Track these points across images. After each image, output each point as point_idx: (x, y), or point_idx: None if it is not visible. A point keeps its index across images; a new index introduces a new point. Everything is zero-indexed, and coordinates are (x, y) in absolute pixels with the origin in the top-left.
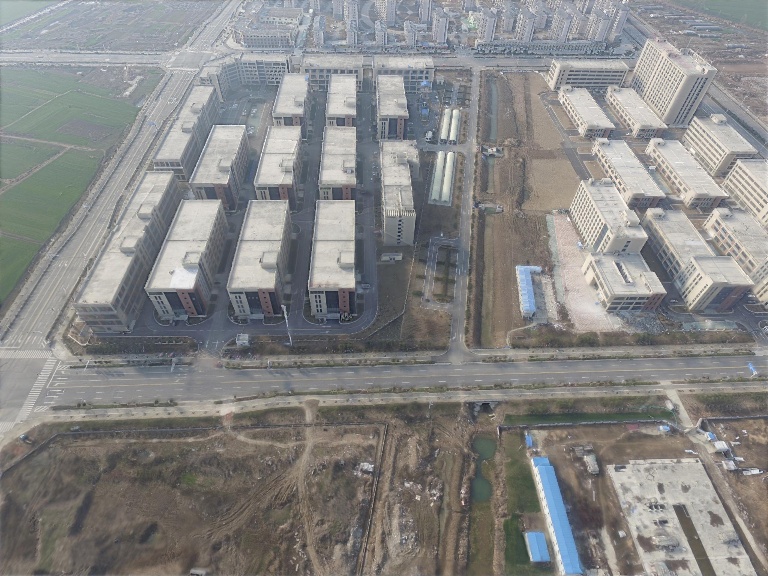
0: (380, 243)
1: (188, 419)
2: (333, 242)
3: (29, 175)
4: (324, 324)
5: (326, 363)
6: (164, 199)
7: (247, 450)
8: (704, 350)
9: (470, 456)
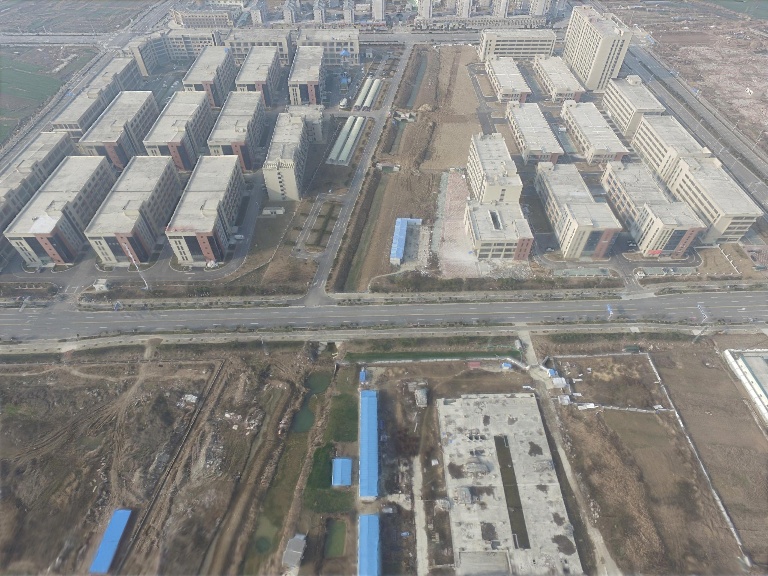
0: (266, 199)
1: (27, 355)
2: (204, 192)
3: None
4: (188, 271)
5: (178, 305)
6: (52, 157)
7: (77, 383)
8: (569, 294)
9: (301, 390)
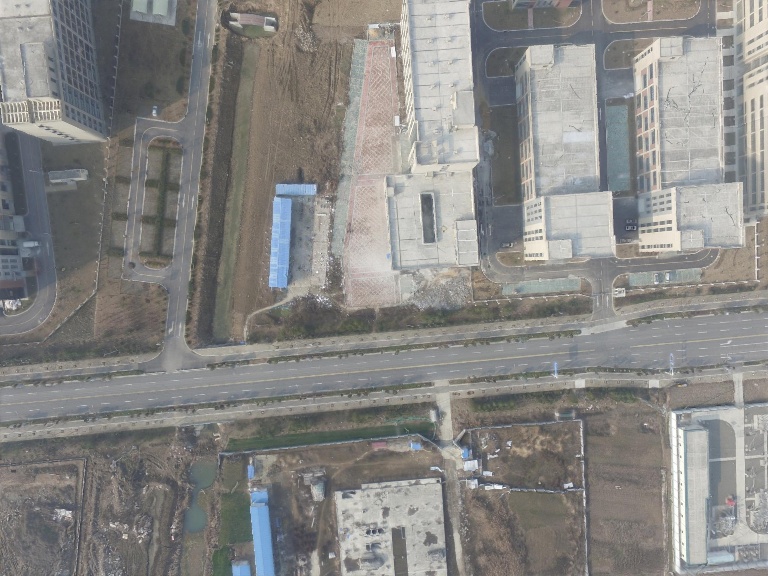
0: None
1: None
2: None
3: None
4: None
5: None
6: None
7: None
8: (514, 331)
9: (185, 487)
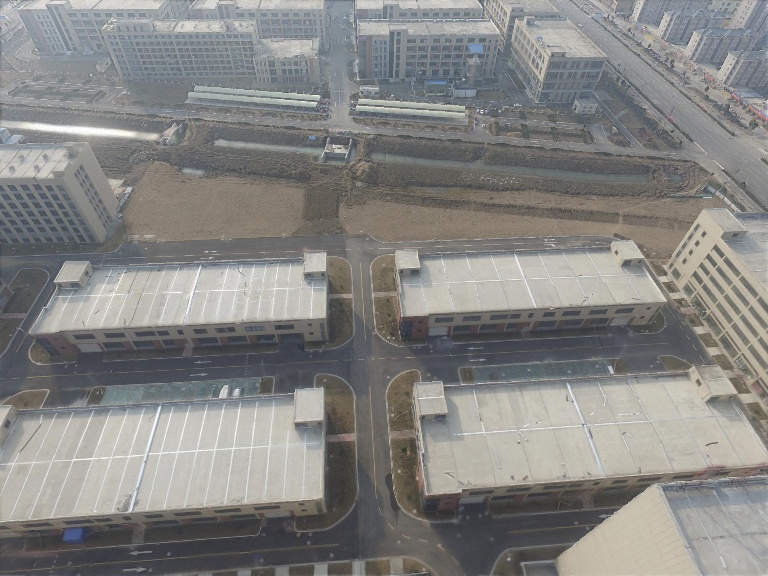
0: None
1: None
2: (95, 4)
3: None
4: None
5: None
6: None
7: None
8: None
9: None
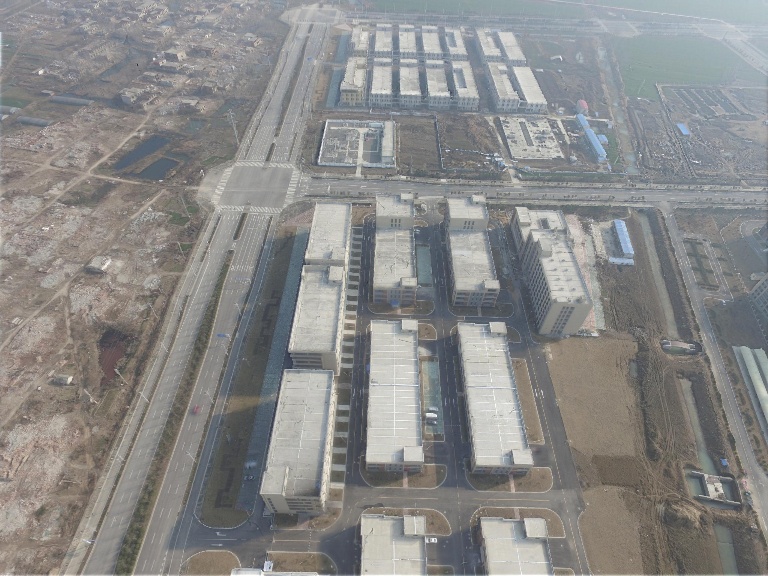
0: None
1: None
2: None
3: None
4: None
5: None
6: None
7: (766, 172)
8: None
9: None
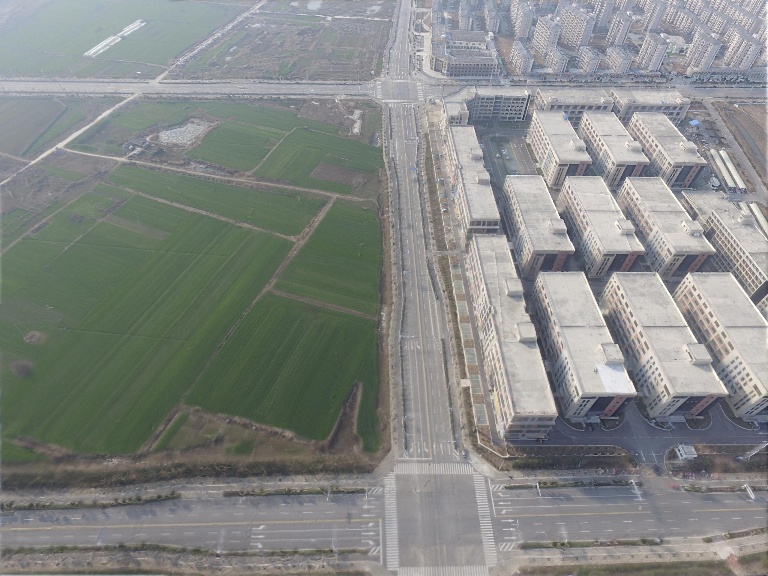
0: None
1: (690, 565)
2: (747, 329)
3: (312, 231)
4: (759, 429)
5: None
6: None
7: None
8: None
9: None
